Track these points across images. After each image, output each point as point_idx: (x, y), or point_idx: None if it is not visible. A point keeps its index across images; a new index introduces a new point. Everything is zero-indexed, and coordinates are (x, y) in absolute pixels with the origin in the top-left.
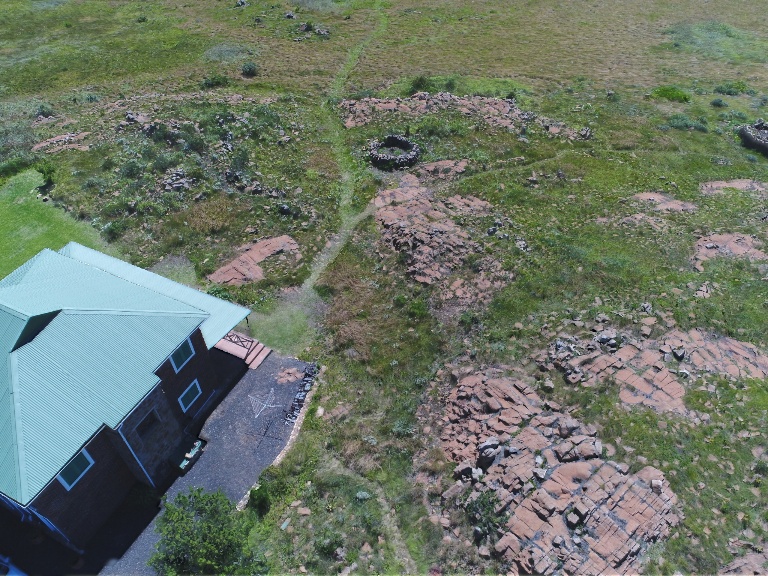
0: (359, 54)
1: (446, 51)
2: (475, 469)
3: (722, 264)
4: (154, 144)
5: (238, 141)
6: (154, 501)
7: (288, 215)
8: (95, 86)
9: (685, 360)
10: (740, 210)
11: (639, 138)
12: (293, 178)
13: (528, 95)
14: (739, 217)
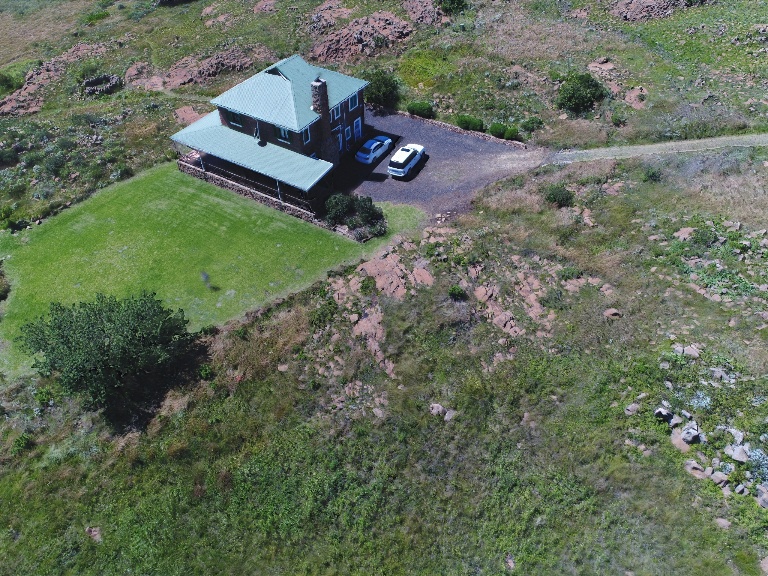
0: None
1: None
2: None
3: (278, 5)
4: None
5: None
6: None
7: None
8: None
9: (332, 7)
10: (238, 4)
11: None
12: None
13: None
14: (244, 4)
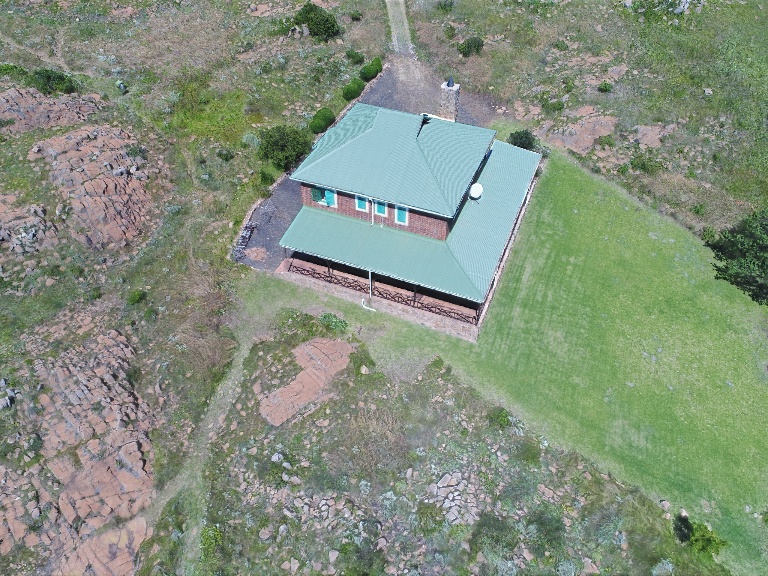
0: None
1: None
2: (134, 172)
3: None
4: None
5: None
6: None
7: None
8: None
9: None
10: None
11: None
12: None
13: None
14: None
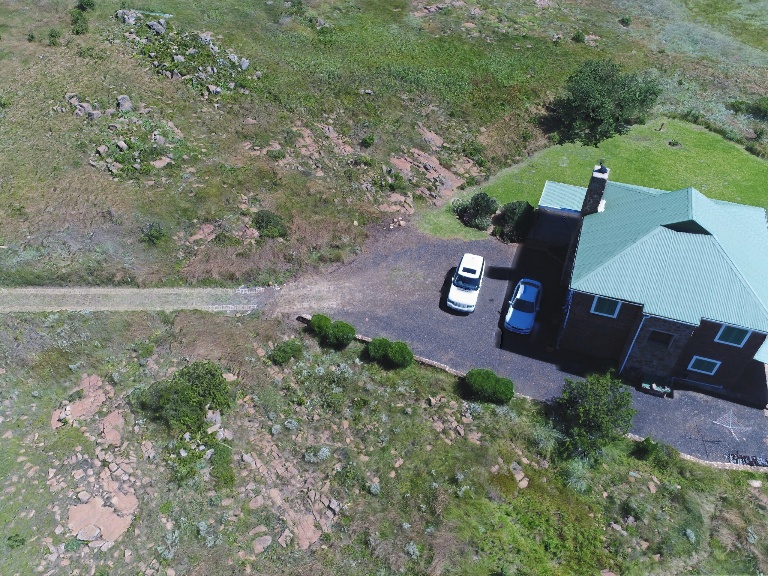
0: None
1: None
2: None
3: None
4: None
5: None
6: None
7: None
8: None
9: None
10: None
11: None
12: None
13: None
14: None
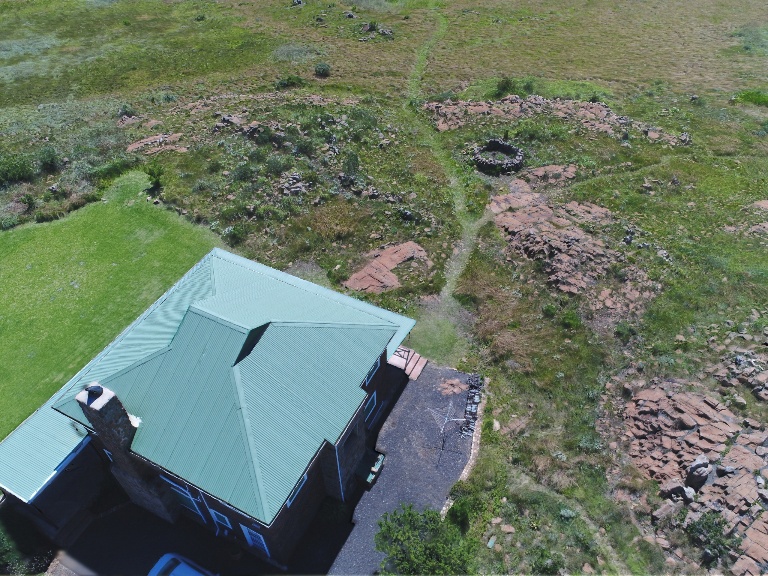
0: (426, 55)
1: (514, 52)
2: (686, 488)
3: None
4: (259, 147)
5: (341, 144)
6: (346, 516)
7: (410, 221)
8: (170, 86)
9: None
10: None
11: (738, 144)
12: (403, 182)
13: (608, 98)
14: None
